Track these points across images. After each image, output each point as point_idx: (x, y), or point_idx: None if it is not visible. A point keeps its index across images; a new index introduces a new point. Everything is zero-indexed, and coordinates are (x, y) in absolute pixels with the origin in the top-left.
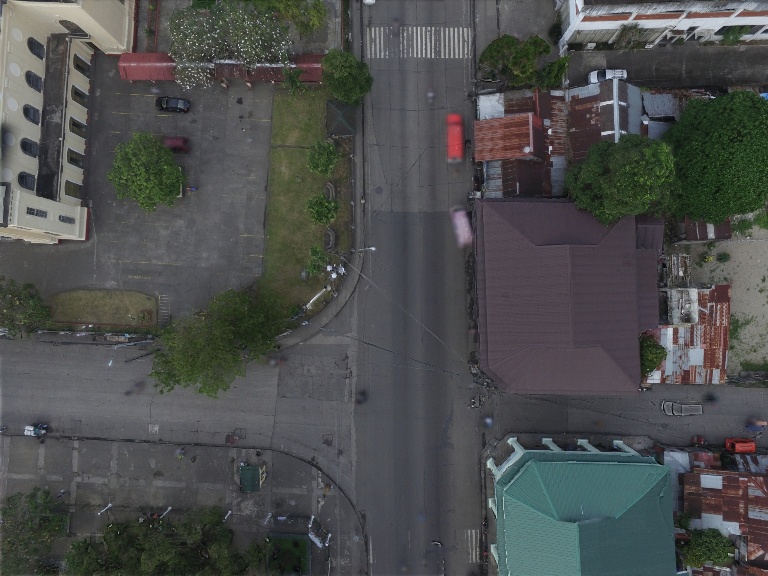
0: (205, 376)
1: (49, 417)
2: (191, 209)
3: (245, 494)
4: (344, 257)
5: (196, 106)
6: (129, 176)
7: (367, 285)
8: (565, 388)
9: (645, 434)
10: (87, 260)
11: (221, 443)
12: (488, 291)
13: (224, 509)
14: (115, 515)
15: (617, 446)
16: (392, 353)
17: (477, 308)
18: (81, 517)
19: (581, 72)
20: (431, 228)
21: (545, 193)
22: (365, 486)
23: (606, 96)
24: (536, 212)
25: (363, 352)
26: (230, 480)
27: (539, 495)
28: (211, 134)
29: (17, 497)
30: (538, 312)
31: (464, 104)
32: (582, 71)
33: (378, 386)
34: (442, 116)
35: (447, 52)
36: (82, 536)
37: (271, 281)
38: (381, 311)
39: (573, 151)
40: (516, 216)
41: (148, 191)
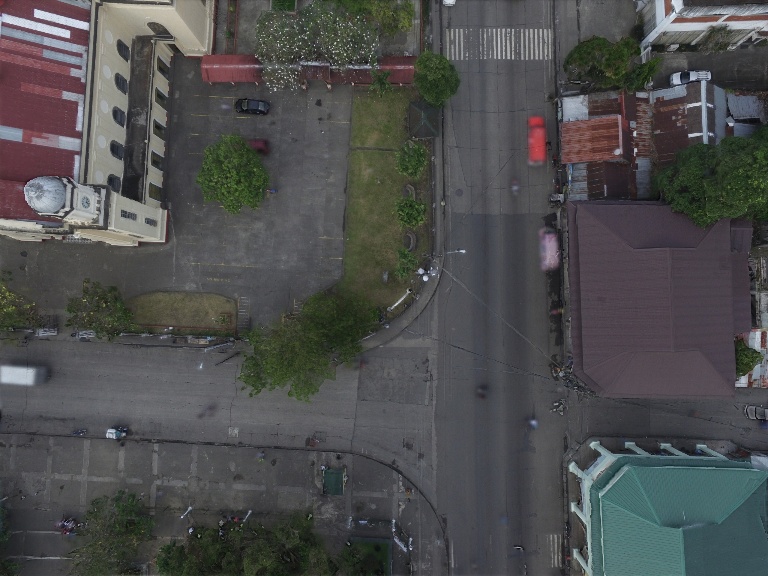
0: (297, 379)
1: (129, 420)
2: (270, 211)
3: (325, 497)
4: (424, 260)
5: (275, 108)
6: (219, 178)
7: (447, 288)
8: (661, 392)
9: (728, 438)
10: (166, 262)
11: (301, 446)
12: (583, 294)
13: (305, 512)
14: (195, 518)
15: (701, 450)
16: (473, 356)
17: (558, 311)
18: (161, 520)
19: (662, 74)
20: (512, 231)
21: (631, 195)
22: (446, 490)
23: (693, 98)
24: (631, 215)
25: (444, 355)
26: (310, 483)
27: (639, 500)
28: (290, 136)
29: (101, 500)
30: (636, 316)
31: (544, 106)
32: (663, 73)
33: (459, 389)
34: (522, 118)
35: (527, 54)
36: (162, 539)
37: (351, 284)
38: (462, 314)
39: (658, 153)
40: (612, 219)
41: (237, 193)
